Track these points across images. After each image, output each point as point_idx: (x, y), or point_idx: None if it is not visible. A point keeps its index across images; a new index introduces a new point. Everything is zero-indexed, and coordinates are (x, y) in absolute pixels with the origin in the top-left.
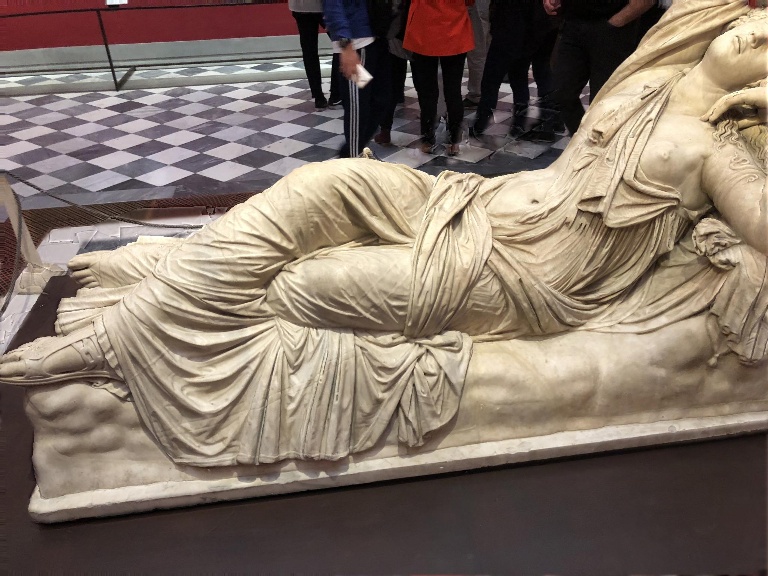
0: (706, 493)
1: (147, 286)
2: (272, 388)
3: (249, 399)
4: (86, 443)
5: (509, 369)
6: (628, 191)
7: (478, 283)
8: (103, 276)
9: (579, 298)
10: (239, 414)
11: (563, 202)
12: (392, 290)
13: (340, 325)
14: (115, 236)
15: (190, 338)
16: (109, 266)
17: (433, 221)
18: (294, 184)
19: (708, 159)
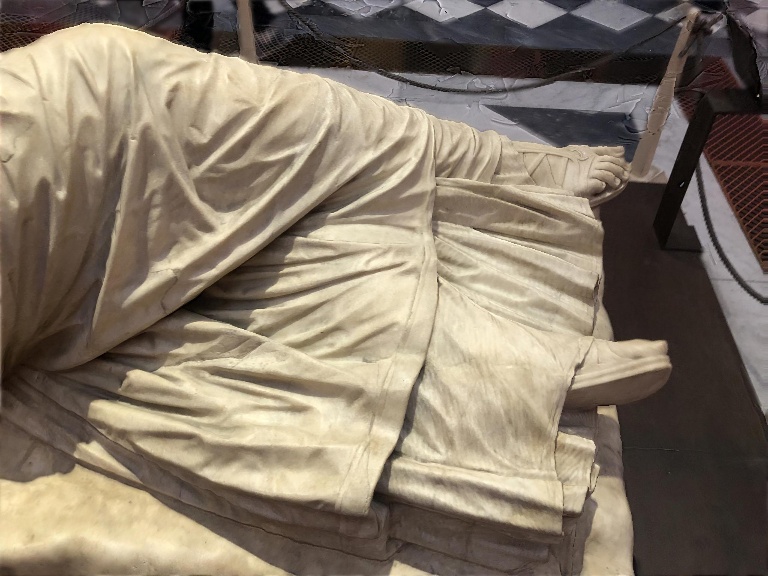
0: None
1: None
2: None
3: None
4: None
5: None
6: None
7: None
8: None
9: None
10: None
11: None
12: None
13: None
14: None
15: None
16: None
17: None
18: None
19: None
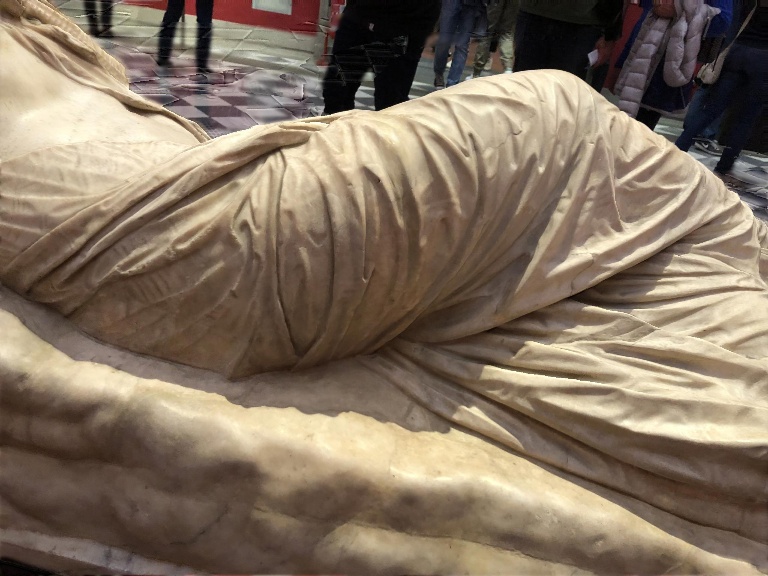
0: None
1: None
2: None
3: None
4: None
5: None
6: None
7: None
8: None
9: None
10: None
11: None
12: None
13: None
14: None
15: None
16: None
17: None
18: None
19: None
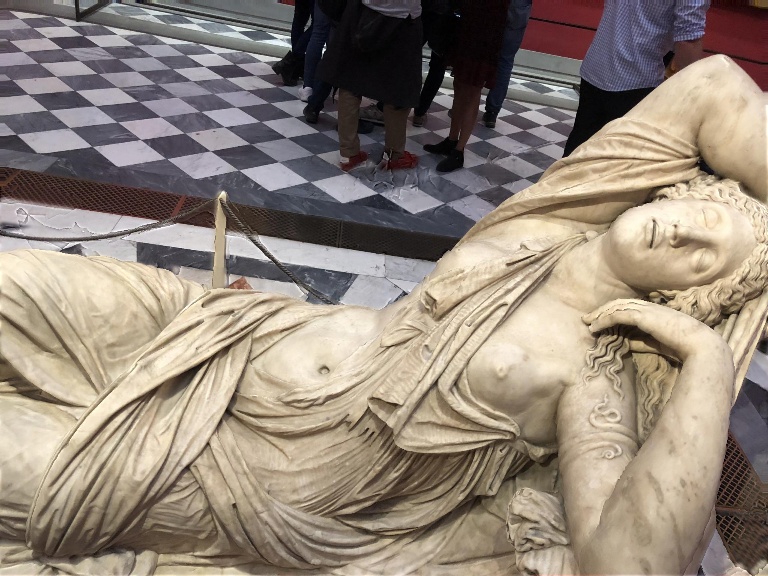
0: None
1: None
2: None
3: None
4: None
5: None
6: (441, 403)
7: (166, 497)
8: None
9: (350, 523)
10: None
11: (352, 388)
12: (1, 494)
13: None
14: None
15: None
16: None
17: (114, 391)
18: None
19: (569, 388)
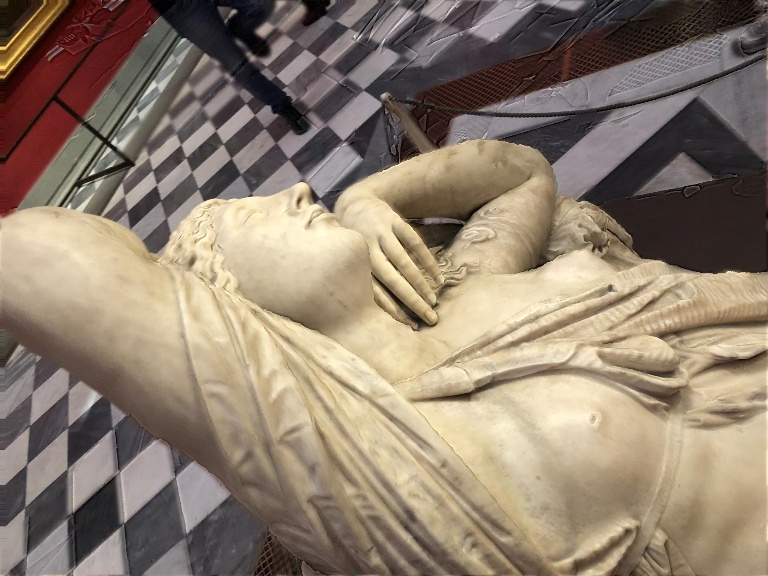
0: (709, 259)
1: None
2: None
3: None
4: None
5: None
6: None
7: None
8: None
9: None
10: None
11: None
12: None
13: None
14: None
15: None
16: None
17: None
18: None
19: None
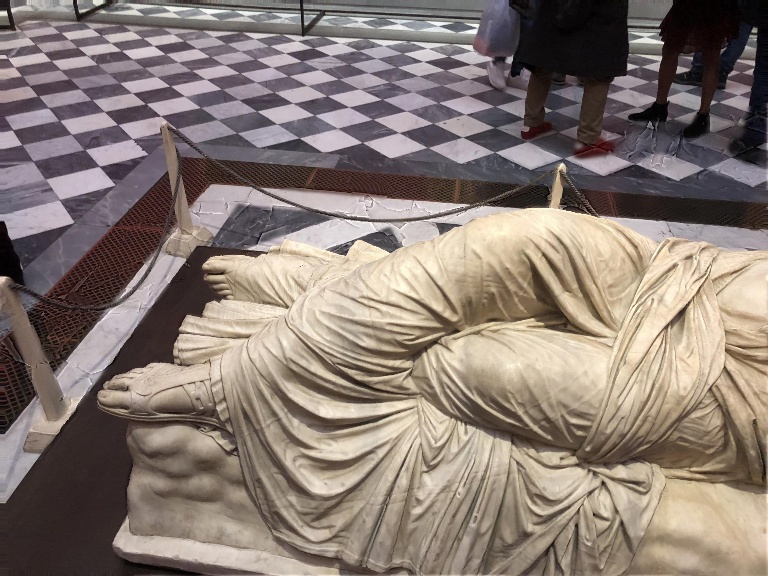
0: None
1: (276, 334)
2: (398, 486)
3: (369, 488)
4: (183, 489)
5: (710, 531)
6: None
7: (693, 413)
8: (237, 286)
9: None
10: (354, 503)
11: None
12: (575, 404)
13: (496, 427)
14: (267, 210)
15: (314, 406)
16: (245, 277)
17: (648, 320)
18: (474, 241)
19: None
